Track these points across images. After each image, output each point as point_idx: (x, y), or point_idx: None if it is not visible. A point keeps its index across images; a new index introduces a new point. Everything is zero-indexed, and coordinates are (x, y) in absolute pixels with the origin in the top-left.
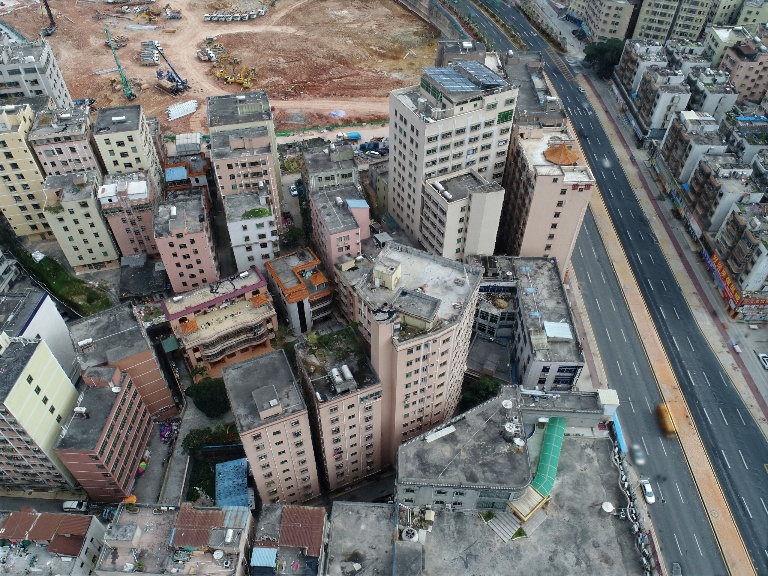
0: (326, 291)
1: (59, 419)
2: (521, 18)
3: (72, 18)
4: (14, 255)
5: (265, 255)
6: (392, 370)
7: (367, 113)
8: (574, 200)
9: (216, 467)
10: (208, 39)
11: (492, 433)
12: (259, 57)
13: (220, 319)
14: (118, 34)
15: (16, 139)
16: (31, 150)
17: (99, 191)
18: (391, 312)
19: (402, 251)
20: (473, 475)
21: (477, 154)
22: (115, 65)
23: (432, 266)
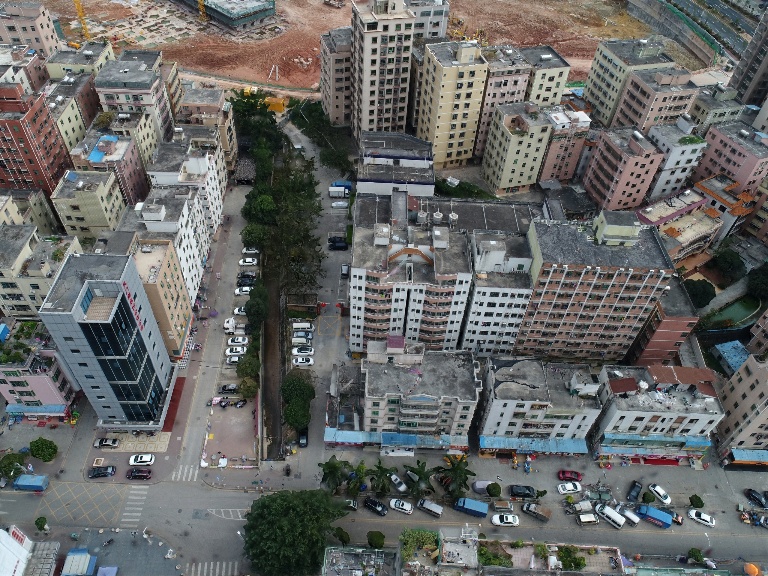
0: (751, 208)
1: None
2: None
3: None
4: None
5: (680, 179)
6: None
7: None
8: None
9: (717, 347)
10: None
11: None
12: (477, 20)
13: (685, 228)
14: None
15: (483, 70)
16: (486, 81)
17: (553, 118)
18: None
19: None
20: None
21: None
22: (348, 23)
23: None
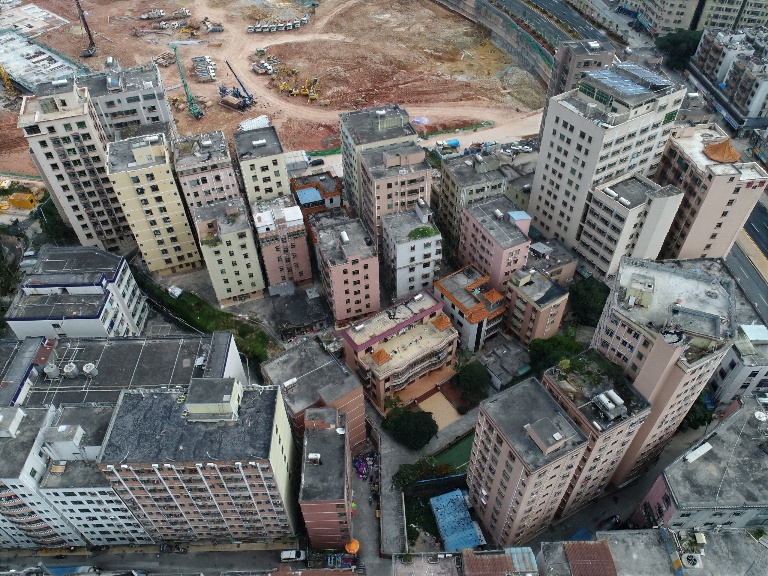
0: (502, 308)
1: (287, 467)
2: (572, 13)
3: (109, 37)
4: (144, 291)
5: (426, 275)
6: (661, 392)
7: (451, 118)
8: (745, 198)
9: (431, 502)
10: (259, 51)
11: (750, 447)
12: (316, 67)
13: (406, 346)
14: (163, 51)
15: (164, 171)
16: (176, 181)
17: (255, 220)
18: (679, 333)
19: (636, 265)
20: (750, 494)
21: (639, 157)
22: (170, 83)
23: (675, 279)
